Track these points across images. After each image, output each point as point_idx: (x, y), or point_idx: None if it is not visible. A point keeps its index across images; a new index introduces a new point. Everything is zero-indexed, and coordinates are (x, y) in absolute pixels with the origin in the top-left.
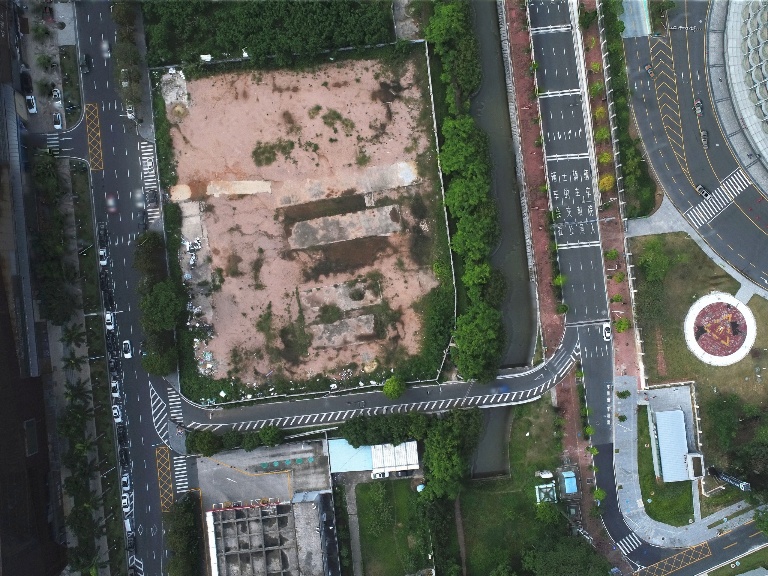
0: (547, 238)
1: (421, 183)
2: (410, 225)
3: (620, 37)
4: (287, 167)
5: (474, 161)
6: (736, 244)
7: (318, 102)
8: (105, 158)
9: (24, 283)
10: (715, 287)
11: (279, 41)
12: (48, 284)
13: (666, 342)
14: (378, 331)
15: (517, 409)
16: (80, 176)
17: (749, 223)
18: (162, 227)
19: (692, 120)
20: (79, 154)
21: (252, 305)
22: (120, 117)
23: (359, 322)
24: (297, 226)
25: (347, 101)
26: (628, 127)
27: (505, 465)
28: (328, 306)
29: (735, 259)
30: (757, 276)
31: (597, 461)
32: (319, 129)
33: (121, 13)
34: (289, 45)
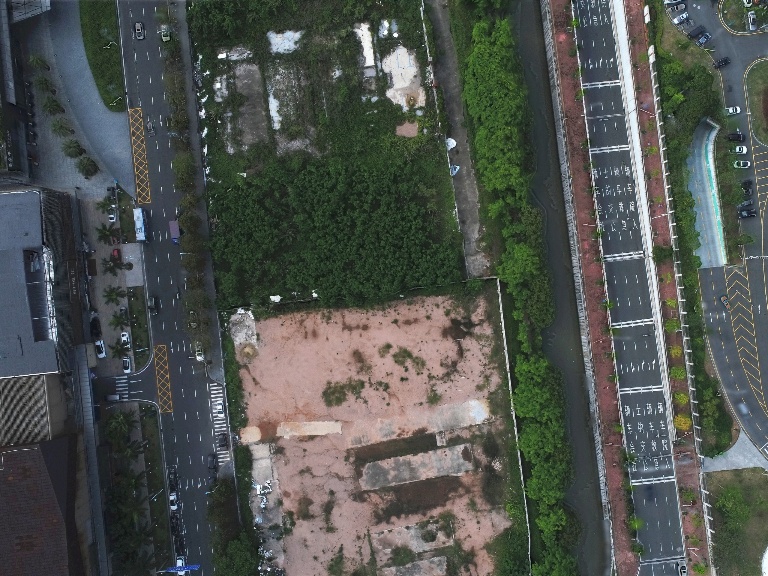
0: (621, 475)
1: (493, 421)
2: (482, 464)
3: (695, 268)
4: (357, 407)
5: (549, 405)
6: None
7: (388, 340)
8: (174, 400)
9: (100, 549)
10: None
11: (350, 285)
12: (122, 542)
13: None
14: (451, 573)
15: None
16: (150, 420)
17: None
18: (233, 472)
19: None
20: (148, 397)
21: (323, 548)
22: (189, 359)
23: (431, 564)
24: (368, 467)
25: (418, 339)
26: (704, 361)
27: None
28: (400, 548)
29: None
30: None
31: None
32: (389, 368)
33: (192, 264)
34: (361, 290)
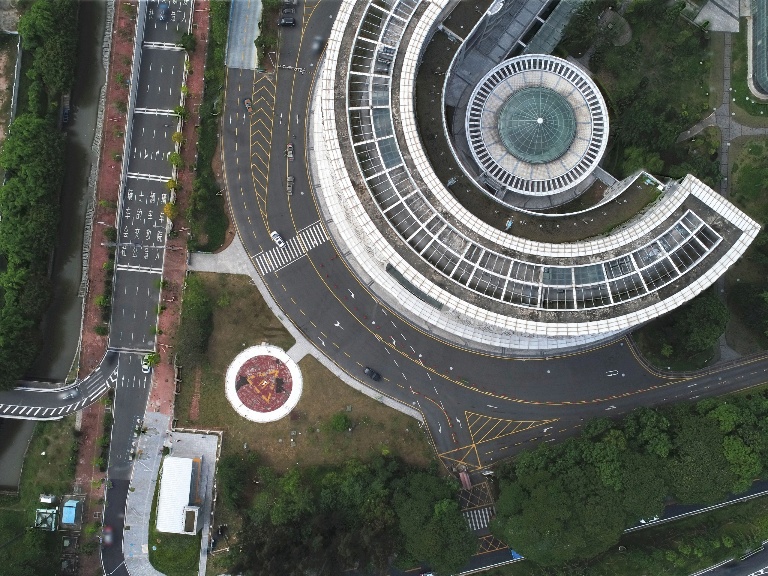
0: (107, 256)
1: None
2: None
3: (225, 66)
4: None
5: (32, 162)
6: (300, 299)
7: None
8: None
9: None
10: (268, 339)
11: None
12: None
13: (204, 386)
14: None
15: (37, 425)
16: None
17: (318, 279)
18: None
19: (281, 163)
20: None
21: None
22: None
23: None
24: None
25: None
26: (212, 158)
27: (16, 481)
28: None
29: (296, 314)
30: (315, 336)
31: (110, 496)
32: None
33: None
34: None
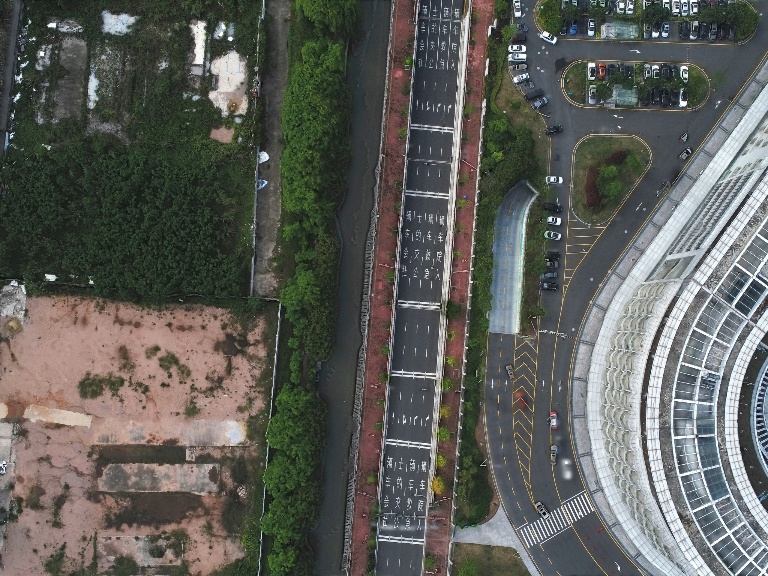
0: (369, 527)
1: (248, 446)
2: (227, 488)
3: (486, 331)
4: (112, 404)
5: (301, 441)
6: (566, 572)
7: (158, 342)
8: None
9: None
10: None
11: (125, 278)
12: None
13: None
14: None
15: None
16: None
17: (584, 552)
18: None
19: (545, 431)
20: None
21: (46, 542)
22: None
23: None
24: (110, 468)
25: (188, 347)
26: (475, 427)
27: None
28: (124, 558)
29: None
30: None
31: None
32: (153, 371)
33: None
34: (134, 285)
